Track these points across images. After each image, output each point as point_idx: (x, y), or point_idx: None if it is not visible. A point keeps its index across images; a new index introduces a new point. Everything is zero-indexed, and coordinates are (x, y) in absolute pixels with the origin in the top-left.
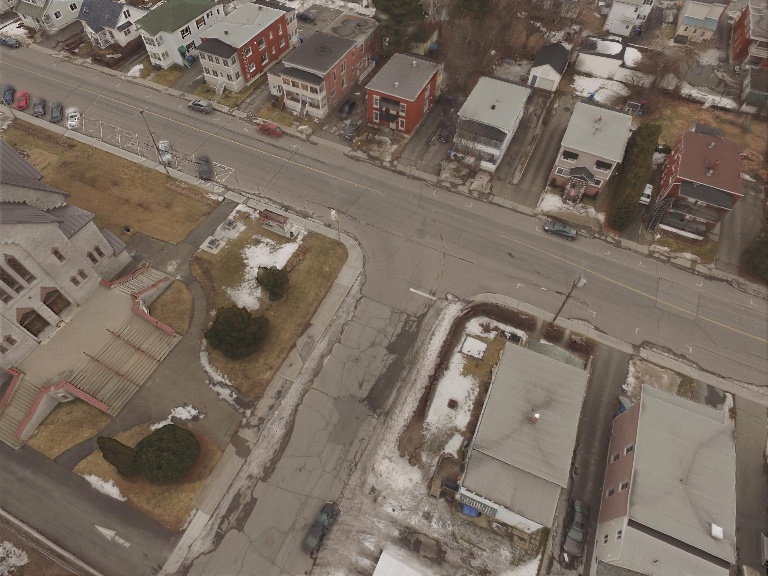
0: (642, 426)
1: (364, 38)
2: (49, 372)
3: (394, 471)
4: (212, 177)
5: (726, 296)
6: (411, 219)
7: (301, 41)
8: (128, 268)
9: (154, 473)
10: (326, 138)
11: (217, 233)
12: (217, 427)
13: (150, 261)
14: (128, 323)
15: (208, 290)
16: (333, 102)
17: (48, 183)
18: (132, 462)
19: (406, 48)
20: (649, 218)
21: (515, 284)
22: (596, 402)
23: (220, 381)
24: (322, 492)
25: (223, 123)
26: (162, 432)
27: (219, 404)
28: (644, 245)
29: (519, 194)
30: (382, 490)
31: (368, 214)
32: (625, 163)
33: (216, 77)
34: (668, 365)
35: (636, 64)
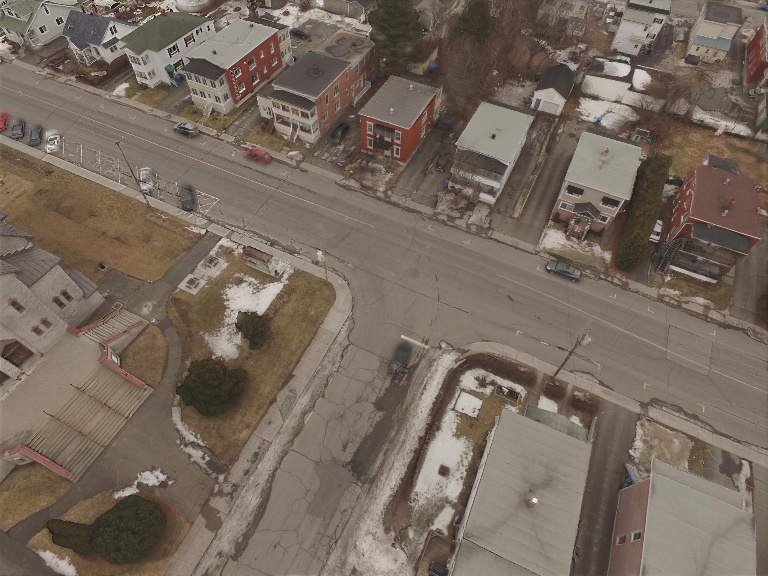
0: (652, 512)
1: (359, 59)
2: (5, 433)
3: (378, 550)
4: (195, 207)
5: (741, 347)
6: (404, 256)
7: (295, 59)
8: (100, 310)
9: (112, 556)
10: (317, 165)
11: (197, 271)
12: (186, 495)
13: (124, 302)
14: (95, 376)
15: (184, 336)
16: (326, 126)
17: (21, 213)
18: (88, 543)
19: (403, 69)
20: (658, 258)
21: (514, 331)
22: (600, 470)
23: (192, 441)
24: (298, 574)
25: (210, 148)
26: (123, 507)
27: (190, 468)
28: (653, 288)
29: (520, 229)
30: (364, 572)
31: (359, 250)
32: (633, 197)
33: (204, 98)
34: (679, 427)
35: (645, 87)
